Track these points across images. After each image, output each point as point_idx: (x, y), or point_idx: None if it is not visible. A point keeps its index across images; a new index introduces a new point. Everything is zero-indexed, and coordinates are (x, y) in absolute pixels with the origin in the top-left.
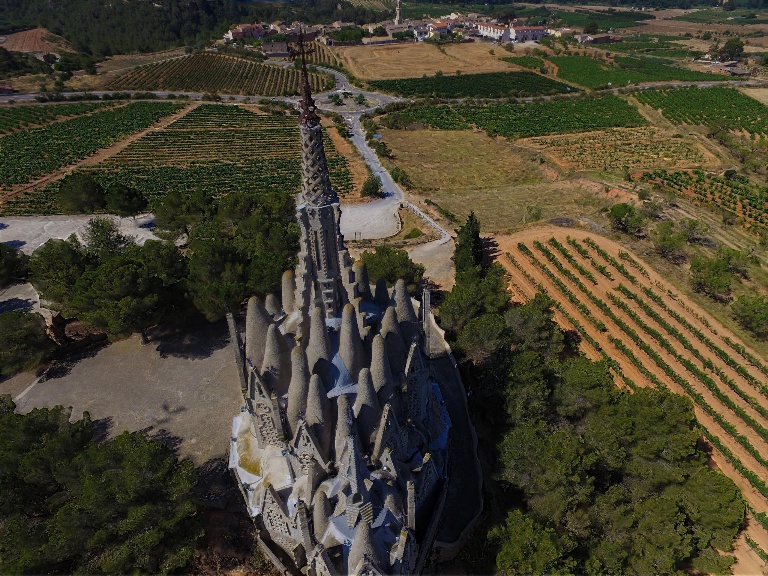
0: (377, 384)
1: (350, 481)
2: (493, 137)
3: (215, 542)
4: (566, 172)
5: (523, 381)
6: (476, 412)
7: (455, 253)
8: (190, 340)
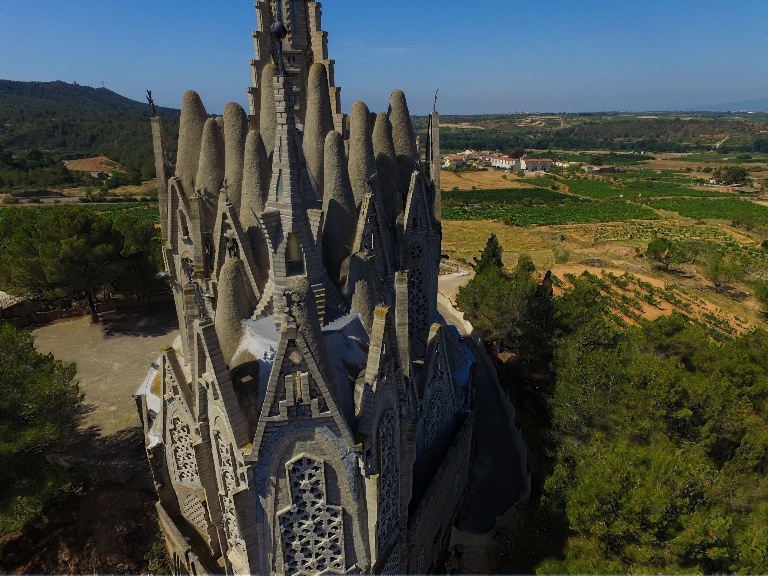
0: (356, 192)
1: (280, 209)
2: (510, 225)
3: (99, 536)
4: (589, 243)
5: (575, 326)
6: (510, 388)
7: (475, 277)
8: (149, 321)
